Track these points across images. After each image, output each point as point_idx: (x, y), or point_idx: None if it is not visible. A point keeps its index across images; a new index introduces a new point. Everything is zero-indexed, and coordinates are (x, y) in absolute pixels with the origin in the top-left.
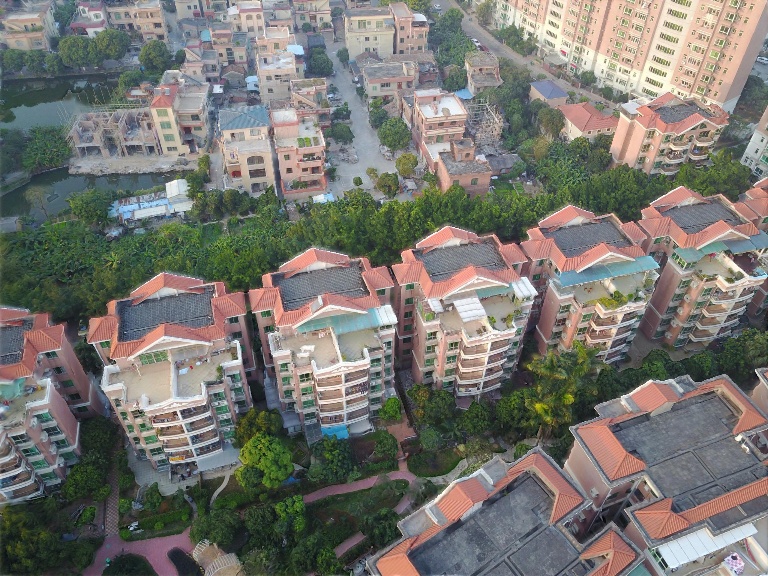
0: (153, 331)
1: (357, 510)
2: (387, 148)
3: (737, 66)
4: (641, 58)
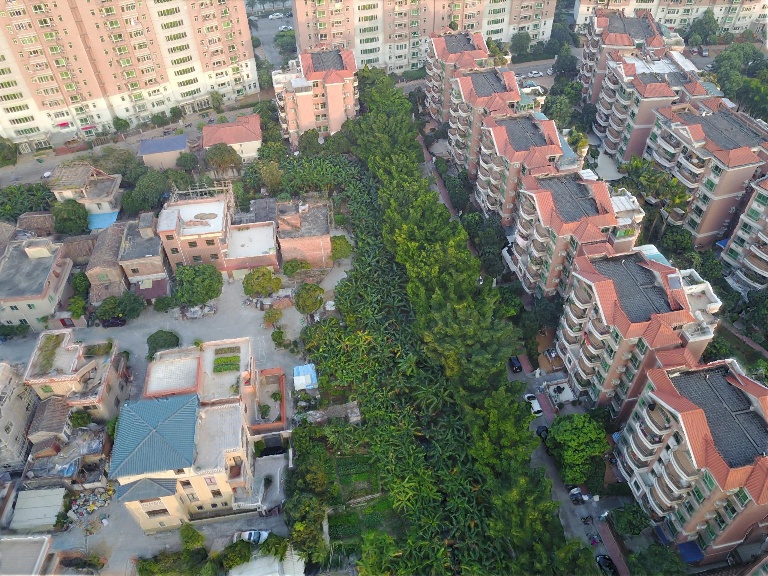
0: (767, 412)
1: (759, 336)
2: (198, 307)
3: (247, 23)
4: (162, 70)
